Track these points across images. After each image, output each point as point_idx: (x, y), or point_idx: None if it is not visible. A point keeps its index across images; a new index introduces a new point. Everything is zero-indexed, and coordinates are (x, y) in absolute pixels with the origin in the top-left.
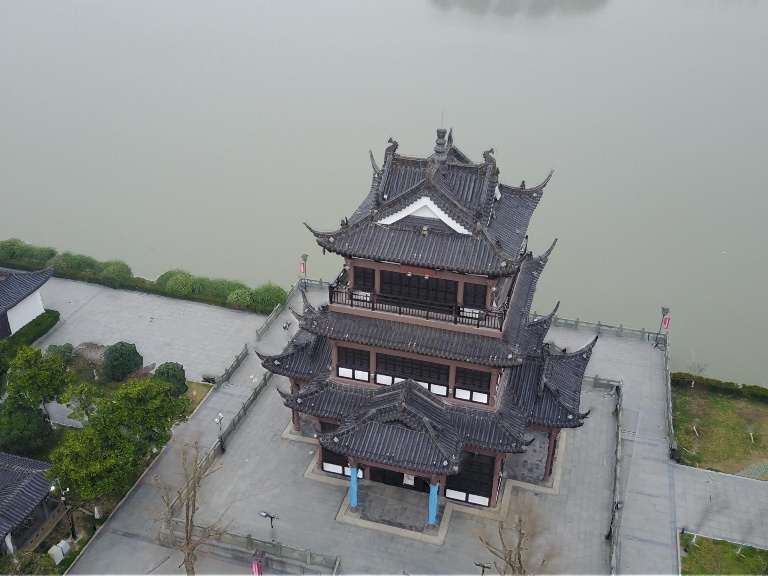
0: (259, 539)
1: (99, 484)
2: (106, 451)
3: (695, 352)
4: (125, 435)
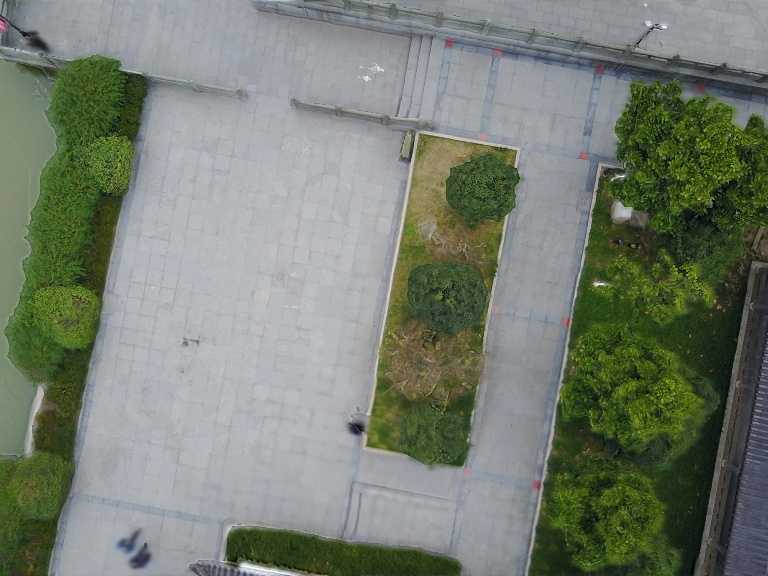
0: None
1: None
2: None
3: None
4: None
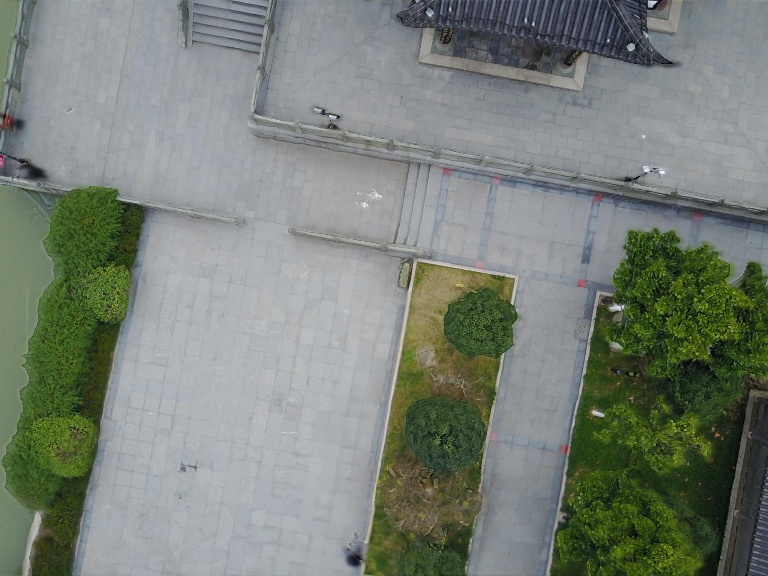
0: None
1: None
2: None
3: None
4: None
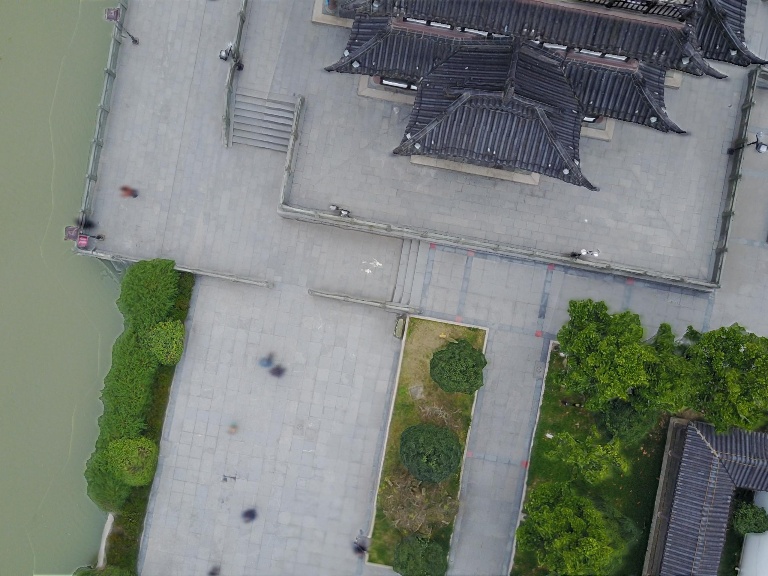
0: None
1: None
2: (705, 370)
3: None
4: (691, 351)
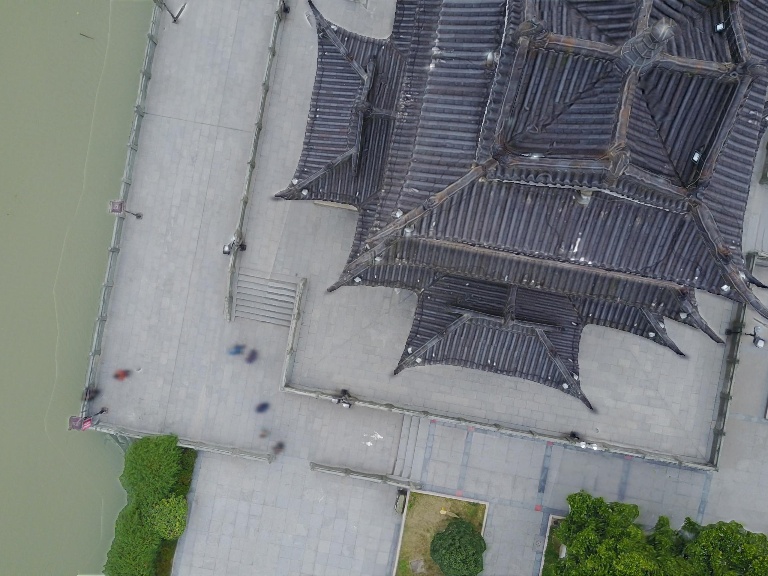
0: None
1: (763, 551)
2: (703, 567)
3: None
4: (689, 551)
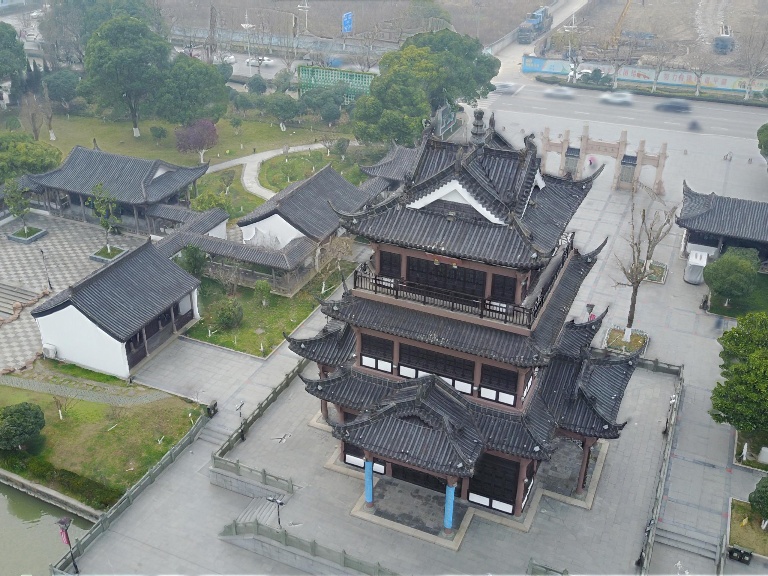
0: (598, 348)
1: None
2: None
3: (20, 574)
4: None
